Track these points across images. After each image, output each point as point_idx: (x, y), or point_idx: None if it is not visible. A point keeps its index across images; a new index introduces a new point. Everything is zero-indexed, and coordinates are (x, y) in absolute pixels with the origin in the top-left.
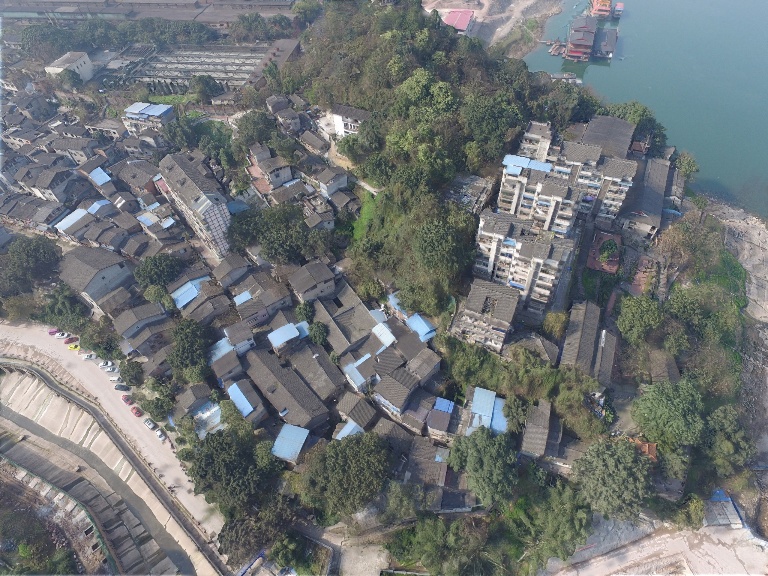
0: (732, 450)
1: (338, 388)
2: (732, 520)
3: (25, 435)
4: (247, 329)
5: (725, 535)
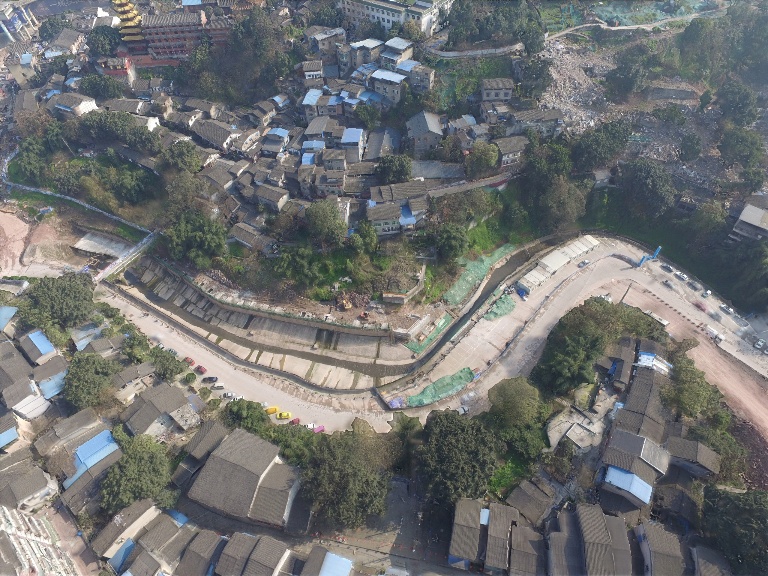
0: None
1: None
2: None
3: (314, 349)
4: (8, 397)
5: None
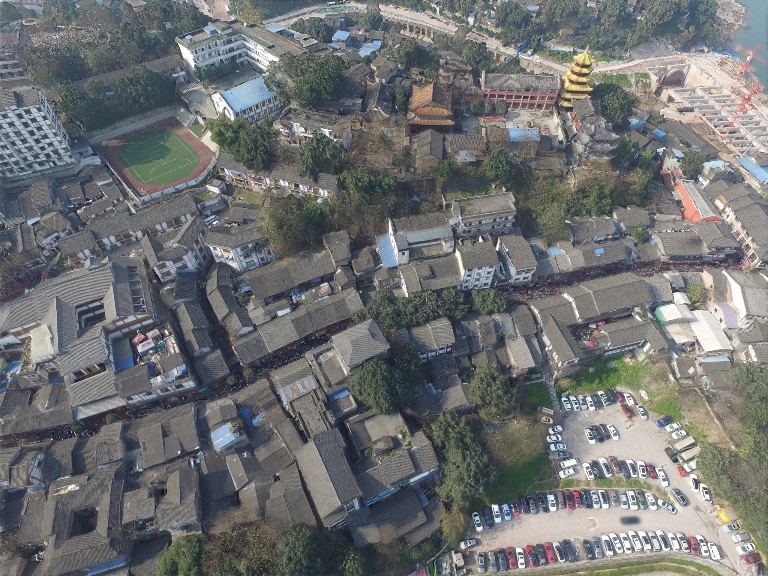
0: (706, 6)
1: (543, 3)
2: (705, 48)
3: None
4: None
5: (702, 55)
